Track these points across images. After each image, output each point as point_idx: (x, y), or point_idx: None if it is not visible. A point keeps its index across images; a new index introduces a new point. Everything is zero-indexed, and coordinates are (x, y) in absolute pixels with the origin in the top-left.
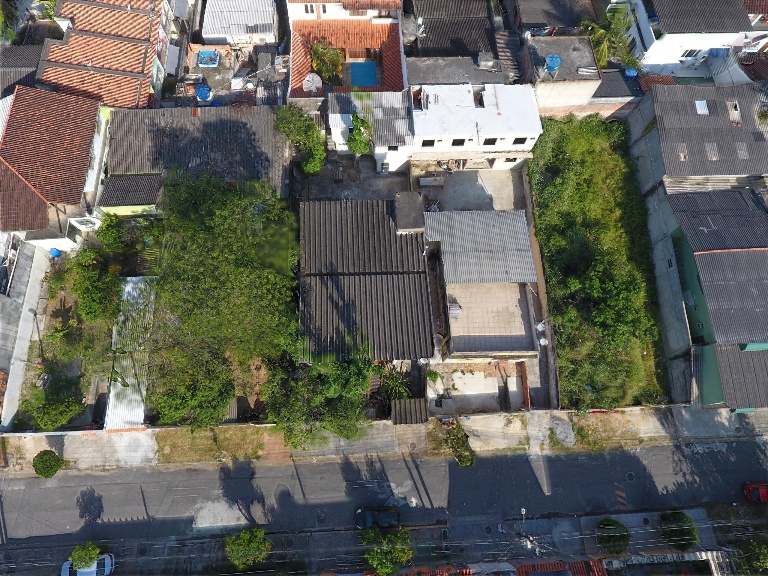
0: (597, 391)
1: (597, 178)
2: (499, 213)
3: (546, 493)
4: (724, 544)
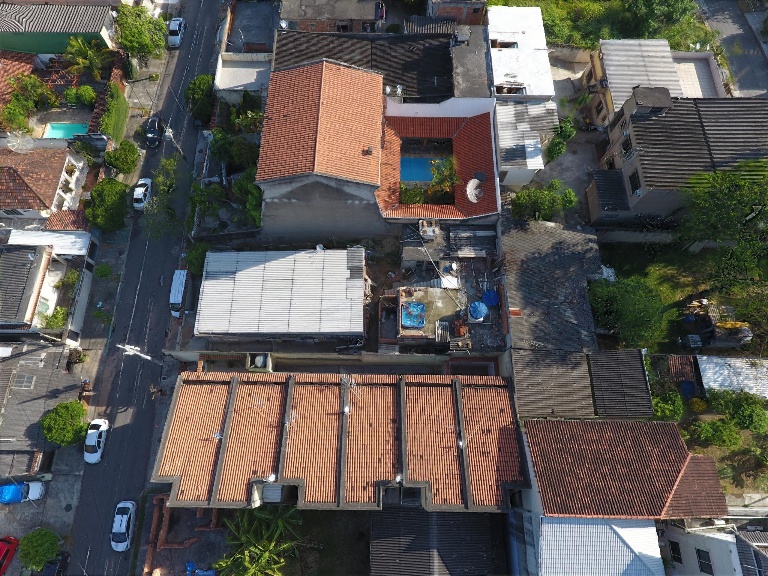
0: (702, 42)
1: (532, 4)
2: (606, 56)
3: (766, 92)
4: (765, 8)
